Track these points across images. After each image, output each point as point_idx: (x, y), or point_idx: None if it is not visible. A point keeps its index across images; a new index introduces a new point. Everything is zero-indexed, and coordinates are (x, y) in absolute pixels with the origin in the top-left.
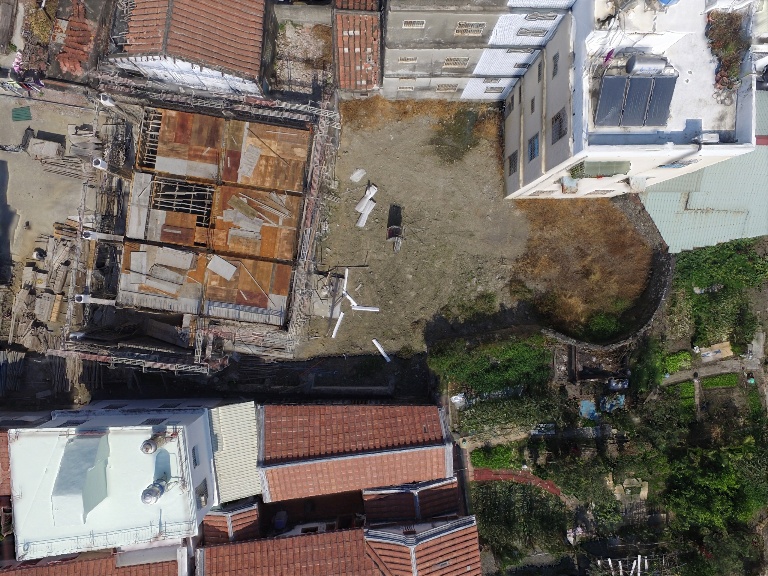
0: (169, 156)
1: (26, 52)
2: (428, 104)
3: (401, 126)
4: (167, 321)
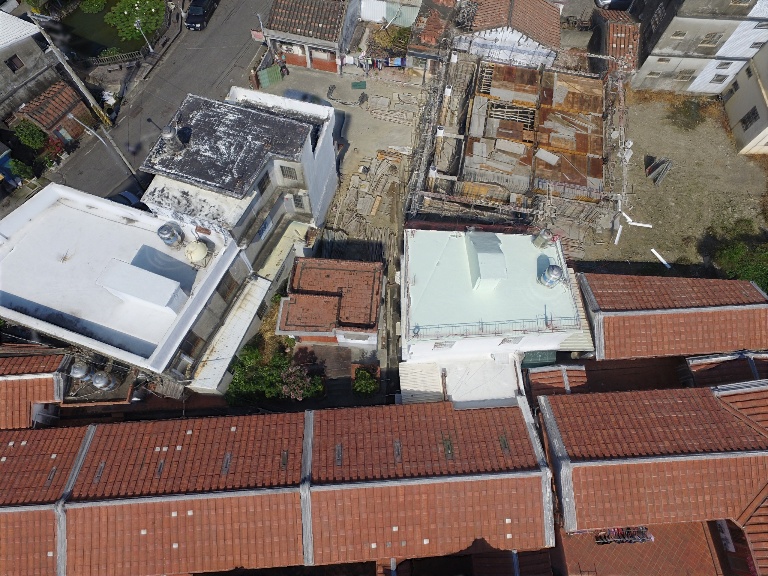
0: (500, 88)
1: (368, 52)
2: (660, 95)
3: (642, 107)
4: None
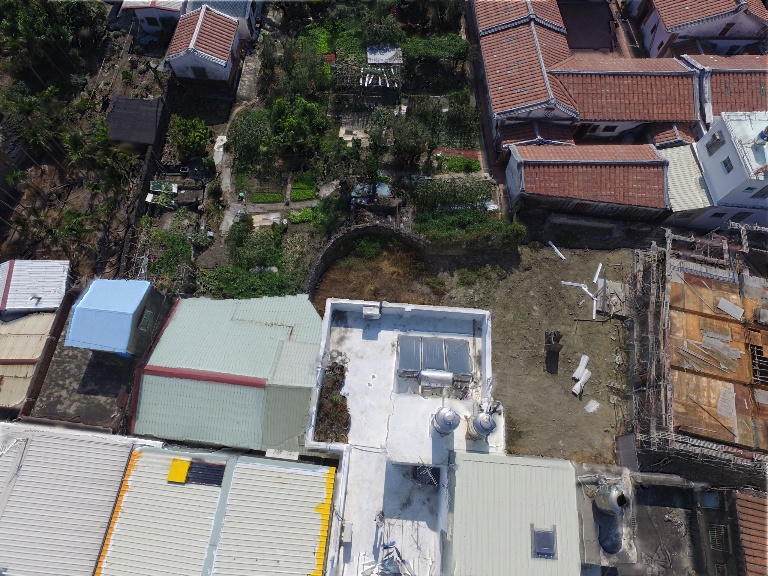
0: None
1: None
2: None
3: (552, 454)
4: None
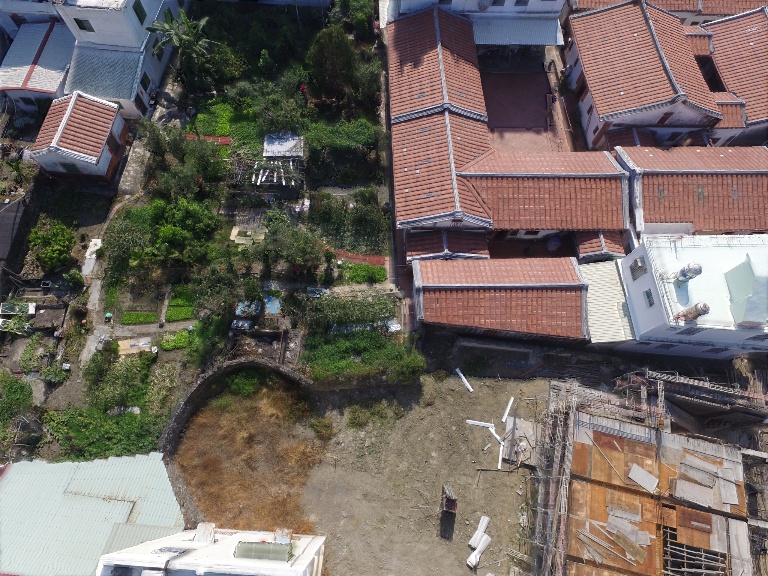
0: None
1: None
2: None
3: None
4: (679, 429)
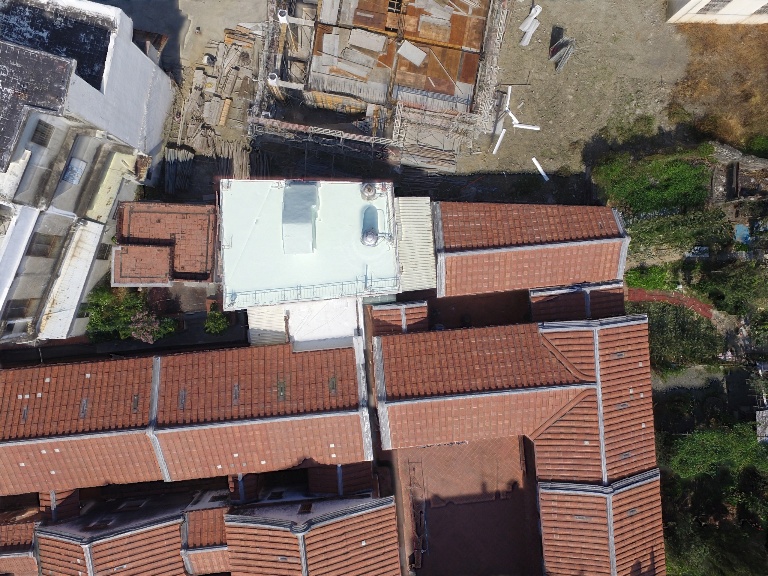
0: None
1: None
2: None
3: None
4: None
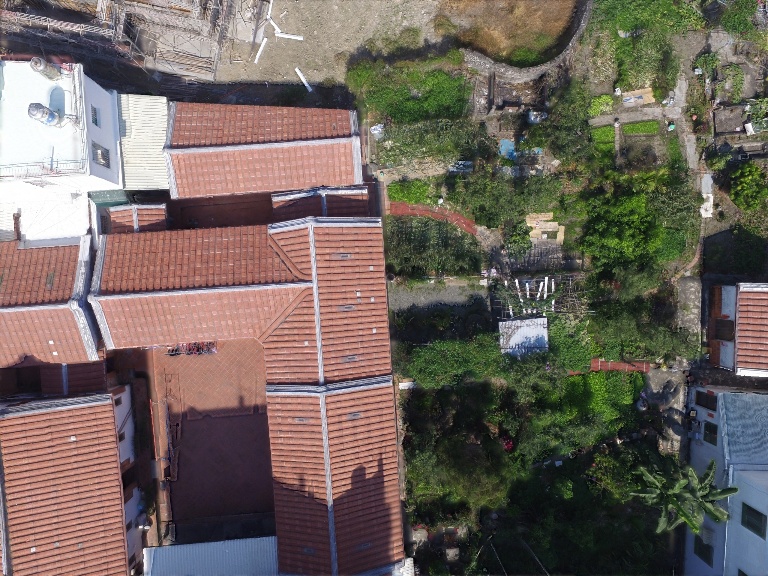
0: None
1: None
2: None
3: None
4: None
